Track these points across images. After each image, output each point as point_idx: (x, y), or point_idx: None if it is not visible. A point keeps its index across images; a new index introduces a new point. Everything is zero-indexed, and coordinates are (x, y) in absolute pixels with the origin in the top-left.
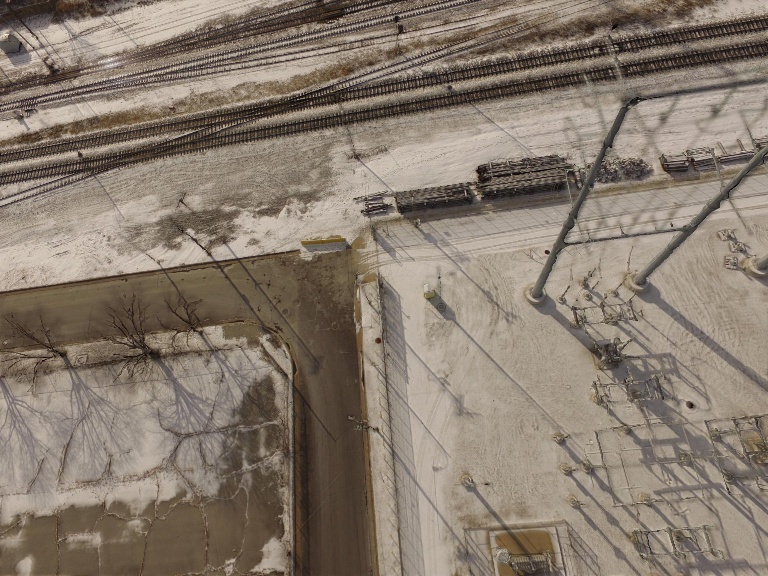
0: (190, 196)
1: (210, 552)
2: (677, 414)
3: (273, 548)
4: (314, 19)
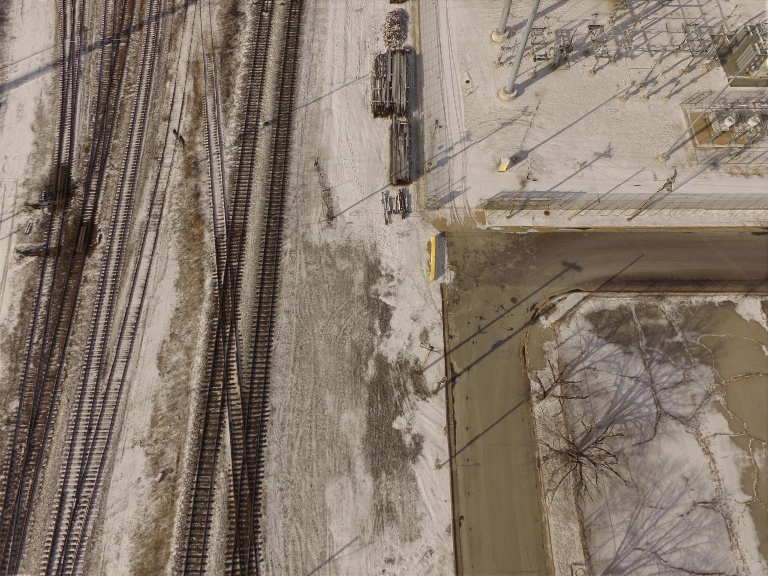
0: (340, 427)
1: (763, 371)
2: (599, 36)
3: (744, 310)
4: (80, 260)
